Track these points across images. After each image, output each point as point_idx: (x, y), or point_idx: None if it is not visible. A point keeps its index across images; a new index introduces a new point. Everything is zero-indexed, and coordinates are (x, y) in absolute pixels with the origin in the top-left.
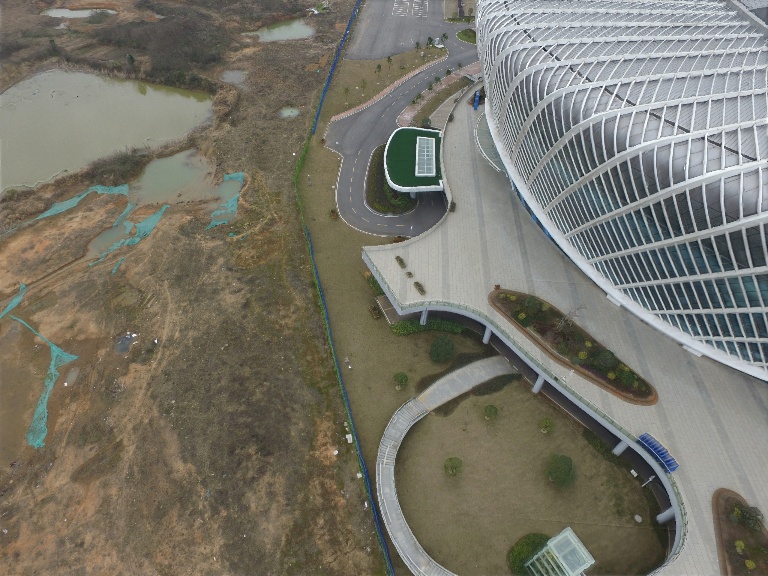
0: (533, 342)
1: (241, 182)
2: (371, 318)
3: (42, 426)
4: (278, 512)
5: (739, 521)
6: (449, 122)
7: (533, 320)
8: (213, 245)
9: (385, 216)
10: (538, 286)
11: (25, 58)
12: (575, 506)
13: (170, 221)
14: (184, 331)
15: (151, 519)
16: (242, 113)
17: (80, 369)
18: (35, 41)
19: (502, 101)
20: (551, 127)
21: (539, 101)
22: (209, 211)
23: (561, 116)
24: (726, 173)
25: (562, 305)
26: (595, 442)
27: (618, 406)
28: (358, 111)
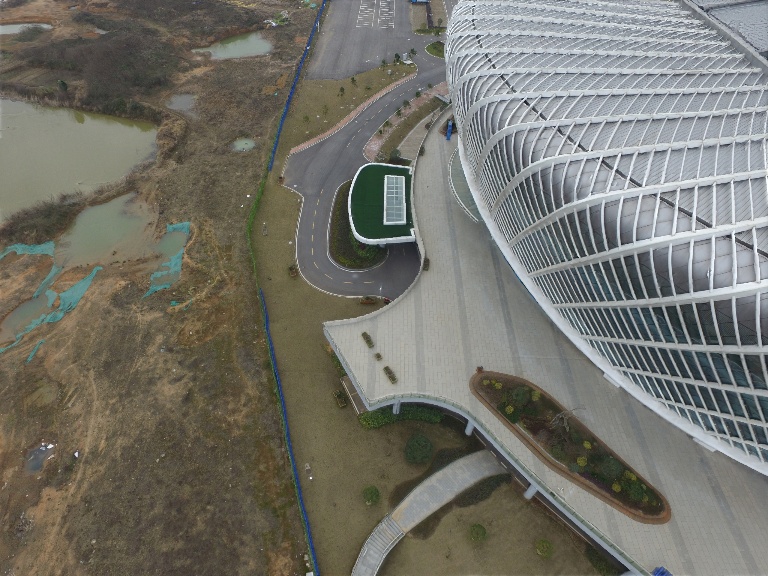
0: (524, 442)
1: (187, 234)
2: (336, 407)
3: None
4: None
5: None
6: (420, 156)
7: (522, 414)
8: (151, 318)
9: (351, 271)
10: (526, 365)
11: None
12: None
13: (101, 288)
14: (111, 439)
15: None
16: (190, 147)
17: None
18: None
19: (478, 154)
20: (538, 199)
21: (523, 168)
22: (148, 273)
23: (550, 190)
24: (763, 288)
25: (554, 389)
26: (600, 565)
27: (626, 527)
28: (320, 141)
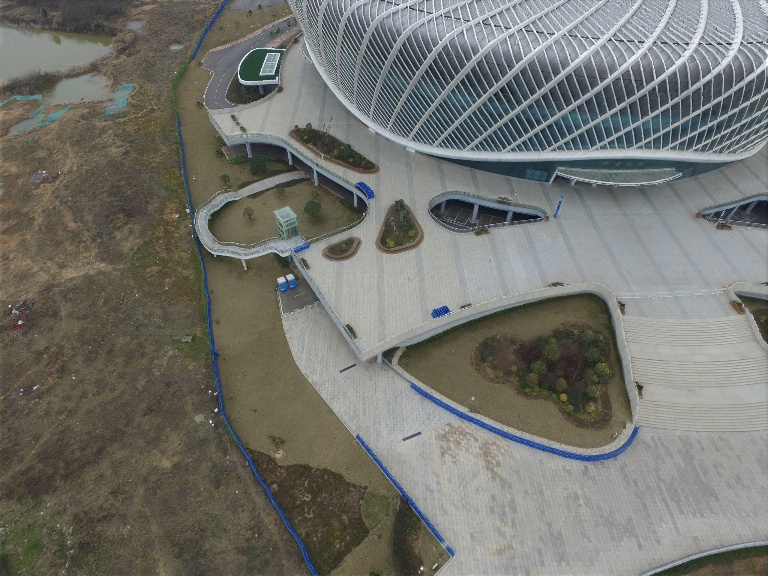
0: (310, 151)
1: (131, 90)
2: (215, 157)
3: None
4: (134, 238)
5: (396, 210)
6: (294, 44)
7: (312, 139)
8: (105, 124)
9: (239, 105)
10: (325, 126)
11: None
12: (323, 230)
13: (73, 112)
14: (80, 166)
15: (52, 246)
16: (137, 48)
17: (5, 189)
18: None
19: None
20: None
21: None
22: (104, 107)
23: None
24: (356, 4)
25: (337, 134)
26: (345, 203)
27: (352, 175)
28: (232, 45)
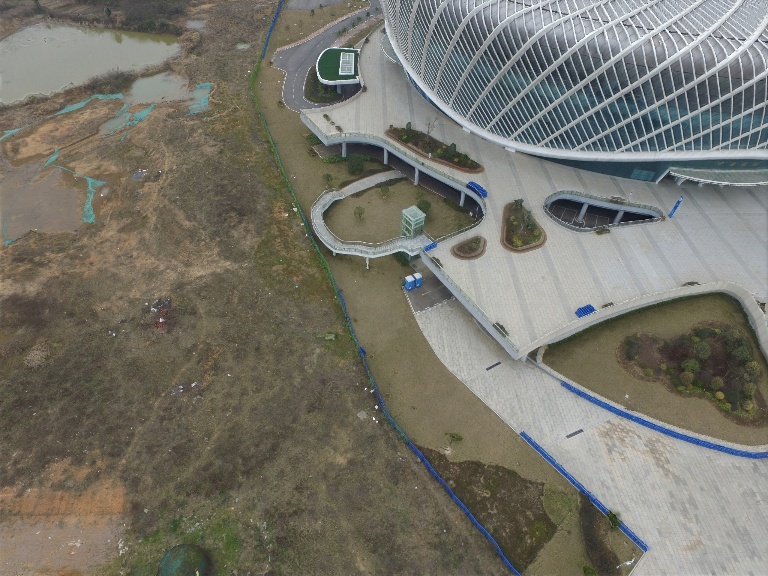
0: (411, 150)
1: (209, 89)
2: (309, 156)
3: (91, 213)
4: (252, 237)
5: (515, 209)
6: (366, 43)
7: (412, 139)
8: (193, 123)
9: (319, 105)
10: (419, 126)
11: (15, 15)
12: (434, 229)
13: (159, 111)
14: (179, 165)
15: (173, 244)
16: (205, 47)
17: (110, 187)
18: (20, 3)
19: None
20: (407, 5)
21: None
22: (187, 106)
23: None
24: (483, 5)
25: (433, 134)
26: (449, 202)
27: (459, 174)
28: (298, 44)
